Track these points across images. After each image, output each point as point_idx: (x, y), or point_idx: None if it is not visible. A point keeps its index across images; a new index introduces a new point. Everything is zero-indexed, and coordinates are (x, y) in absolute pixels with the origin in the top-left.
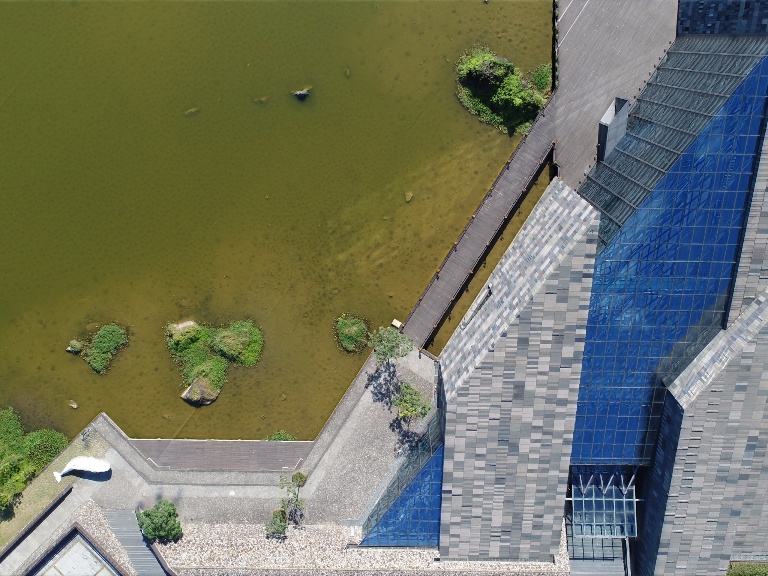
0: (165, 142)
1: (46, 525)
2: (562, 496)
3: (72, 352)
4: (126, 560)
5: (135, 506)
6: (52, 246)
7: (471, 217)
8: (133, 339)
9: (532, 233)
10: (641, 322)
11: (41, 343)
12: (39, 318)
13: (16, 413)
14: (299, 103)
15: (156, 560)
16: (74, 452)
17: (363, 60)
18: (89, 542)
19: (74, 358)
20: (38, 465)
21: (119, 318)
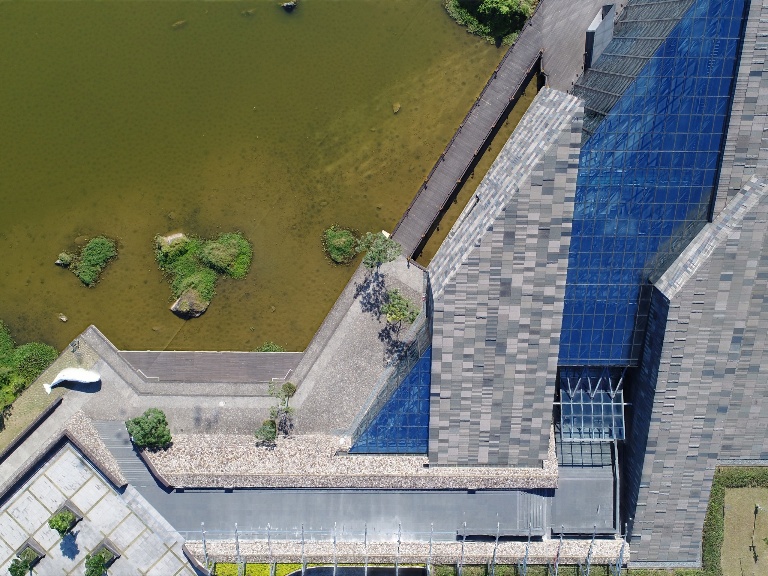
0: (153, 55)
1: (36, 436)
2: (550, 398)
3: (61, 265)
4: (116, 468)
5: (125, 417)
6: (40, 159)
7: (459, 127)
8: (122, 252)
9: (519, 139)
10: (627, 216)
11: (30, 256)
12: (28, 231)
13: (6, 326)
14: (286, 15)
15: (146, 469)
16: (64, 364)
17: None
18: (79, 450)
19: (63, 271)
20: (28, 378)
21: (108, 231)
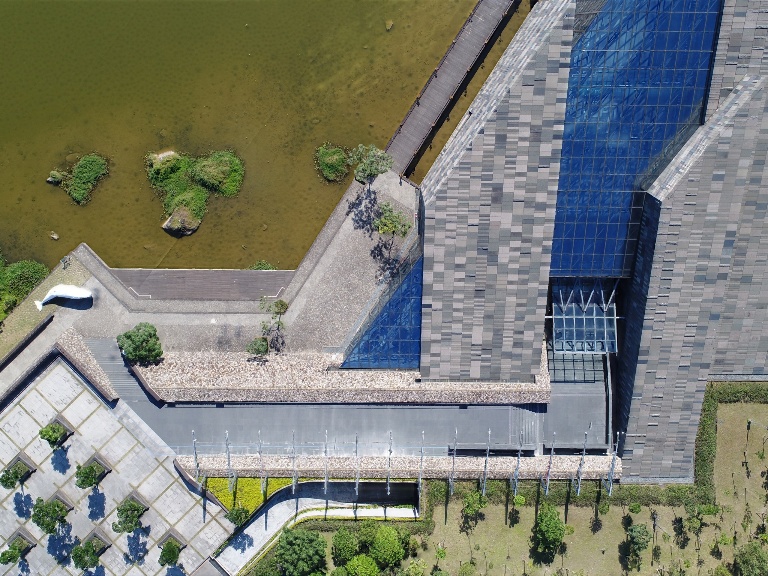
0: None
1: (28, 353)
2: (542, 310)
3: (52, 182)
4: (107, 383)
5: (116, 334)
6: (31, 77)
7: (451, 43)
8: (113, 170)
9: (512, 51)
10: (619, 119)
11: (21, 174)
12: (19, 149)
13: None
14: None
15: (137, 384)
16: (55, 281)
17: None
18: (70, 364)
19: (54, 189)
20: (19, 296)
21: (99, 149)
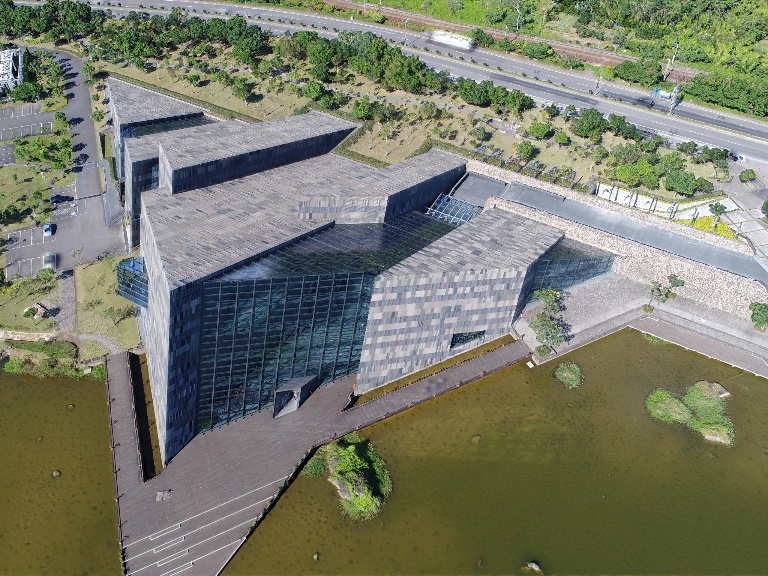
0: None
1: None
2: None
3: None
4: None
5: None
6: None
7: None
8: (767, 450)
9: (403, 352)
10: (381, 244)
11: None
12: None
13: None
14: (541, 561)
15: None
16: None
17: (460, 567)
18: None
19: None
20: None
21: None
